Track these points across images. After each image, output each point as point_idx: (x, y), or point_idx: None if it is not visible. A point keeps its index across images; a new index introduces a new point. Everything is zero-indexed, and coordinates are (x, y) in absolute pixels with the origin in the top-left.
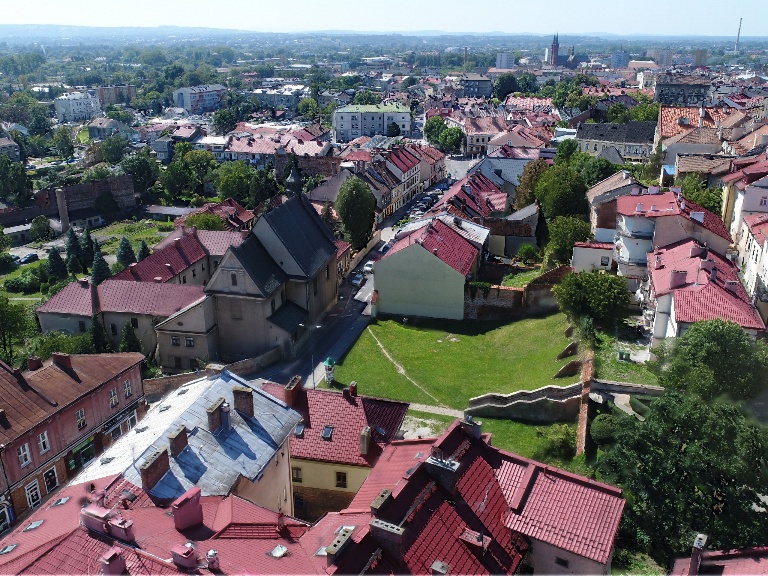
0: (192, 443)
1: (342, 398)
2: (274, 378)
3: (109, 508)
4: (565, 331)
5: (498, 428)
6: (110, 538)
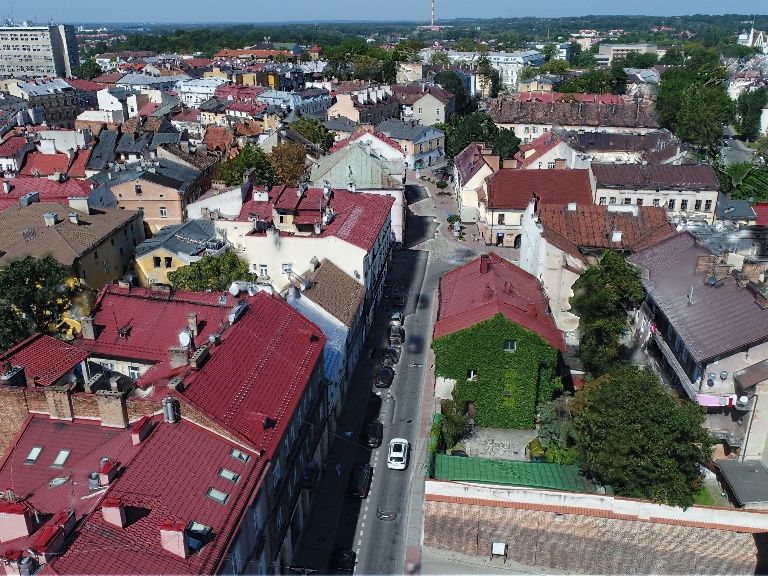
0: None
1: None
2: None
3: (44, 529)
4: None
5: None
6: (69, 539)
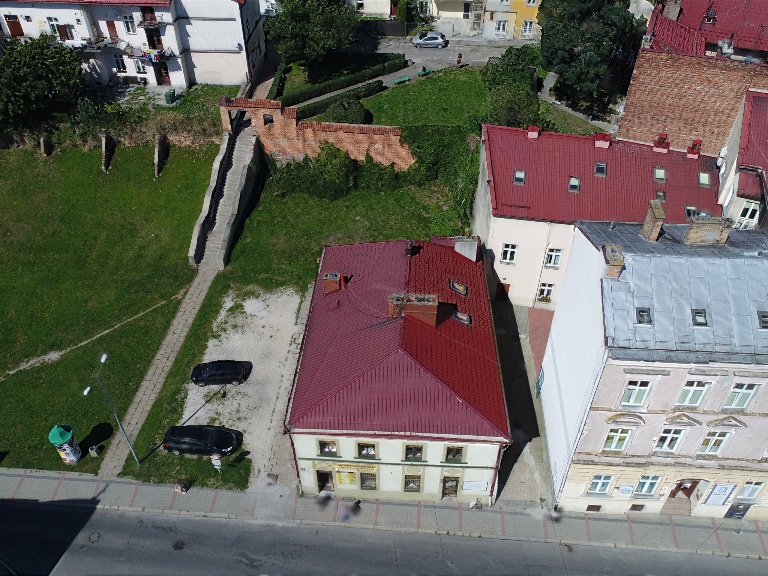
0: (763, 250)
1: (413, 259)
2: (37, 572)
3: None
4: (44, 150)
5: (263, 230)
6: None
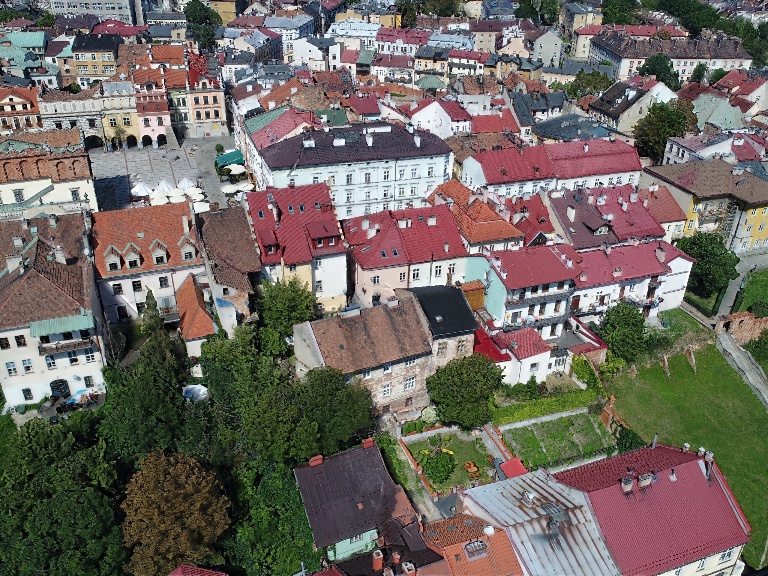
0: None
1: None
2: None
3: None
4: None
5: None
6: None
